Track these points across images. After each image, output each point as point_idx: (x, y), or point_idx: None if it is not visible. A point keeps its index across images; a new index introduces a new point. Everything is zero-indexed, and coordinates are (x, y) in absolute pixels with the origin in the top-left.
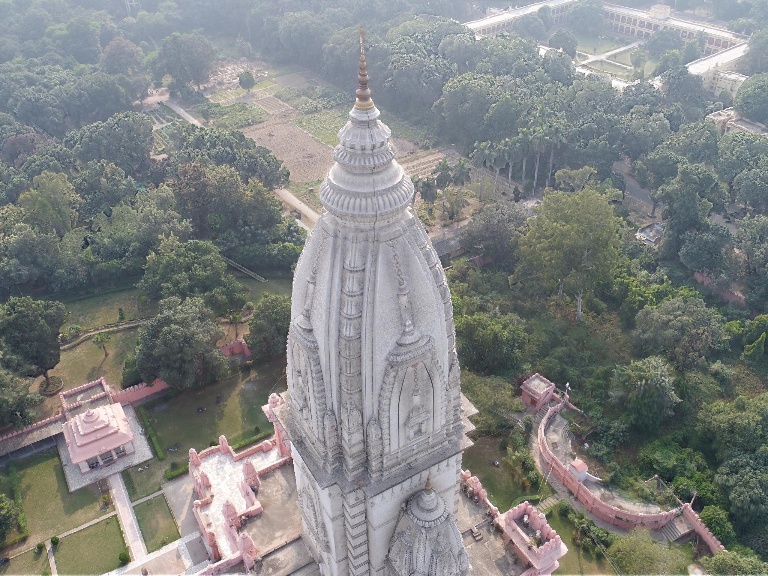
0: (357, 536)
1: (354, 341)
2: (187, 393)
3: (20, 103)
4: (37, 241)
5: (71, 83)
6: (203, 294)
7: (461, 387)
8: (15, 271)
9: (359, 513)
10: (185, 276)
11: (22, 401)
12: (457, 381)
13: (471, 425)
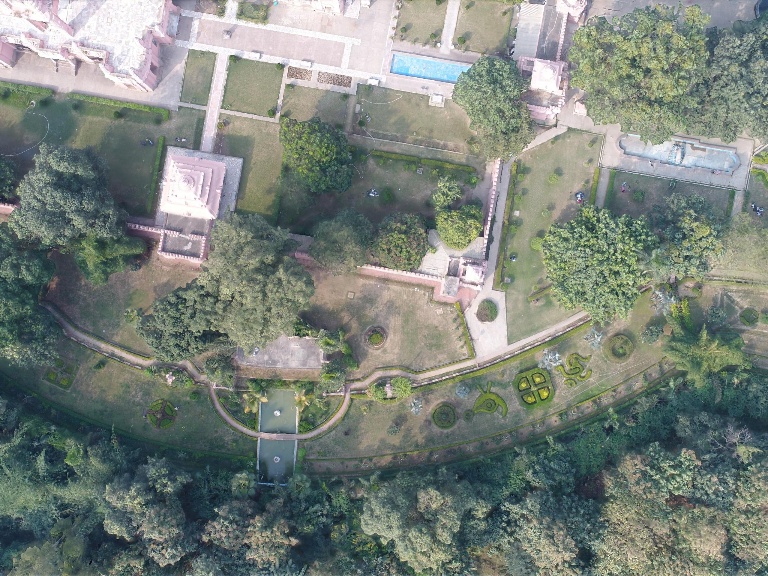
0: None
1: None
2: None
3: None
4: None
5: None
6: (3, 234)
7: None
8: None
9: None
10: (1, 271)
11: None
12: None
13: None
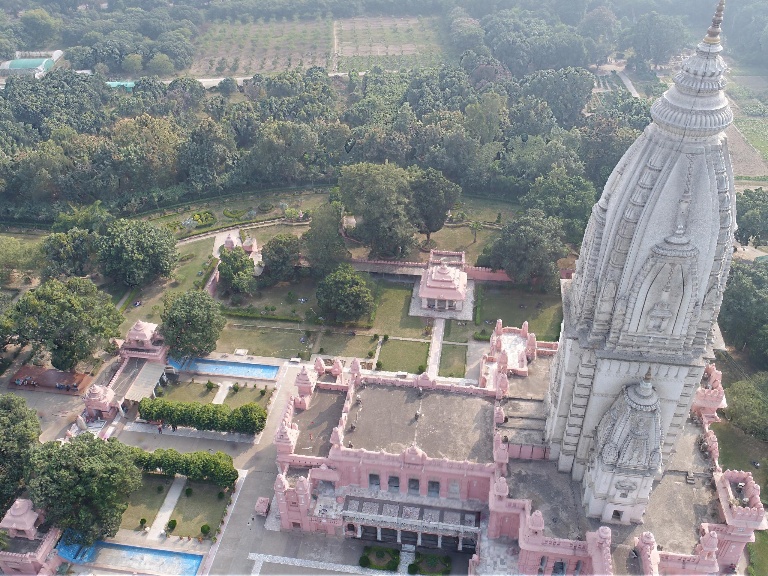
0: (579, 396)
1: (631, 224)
2: (518, 291)
3: (501, 42)
4: (465, 141)
5: (547, 36)
6: (565, 219)
7: (757, 384)
8: (441, 157)
9: (587, 375)
10: (558, 200)
11: (406, 240)
12: (712, 306)
13: (712, 354)
